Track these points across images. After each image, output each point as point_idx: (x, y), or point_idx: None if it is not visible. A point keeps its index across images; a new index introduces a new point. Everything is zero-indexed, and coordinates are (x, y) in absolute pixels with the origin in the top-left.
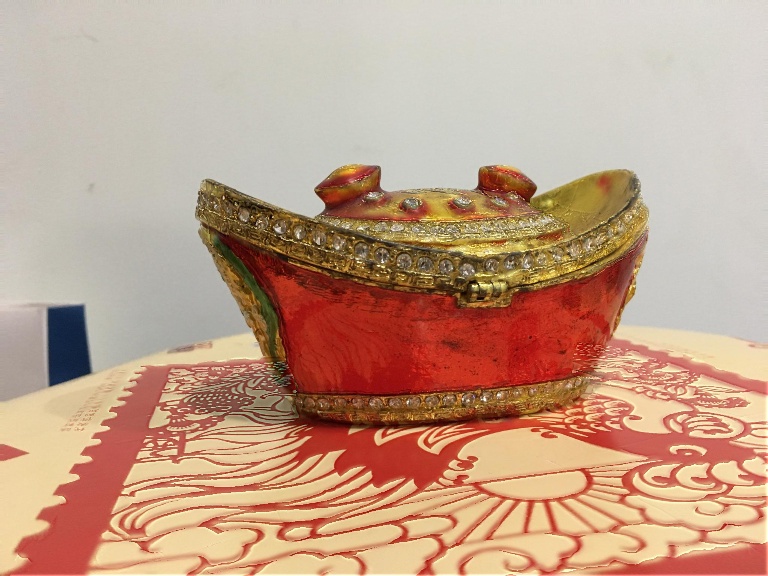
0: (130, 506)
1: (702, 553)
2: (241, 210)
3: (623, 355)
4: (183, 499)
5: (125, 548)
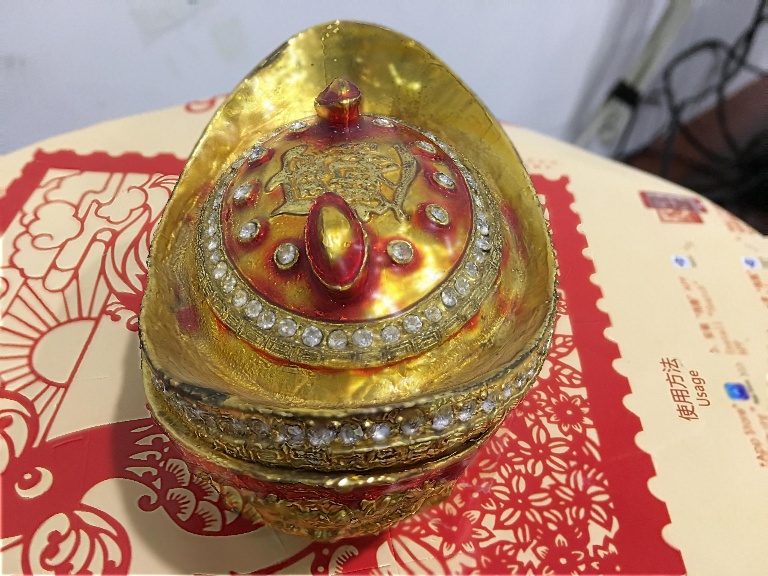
0: None
1: None
2: None
3: None
4: None
5: (138, 181)
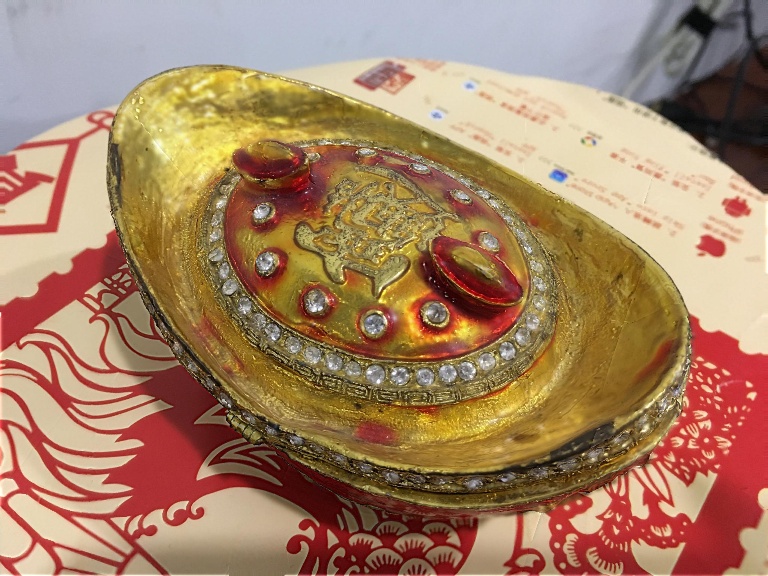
0: (4, 361)
1: None
2: None
3: (680, 475)
4: (27, 380)
5: None
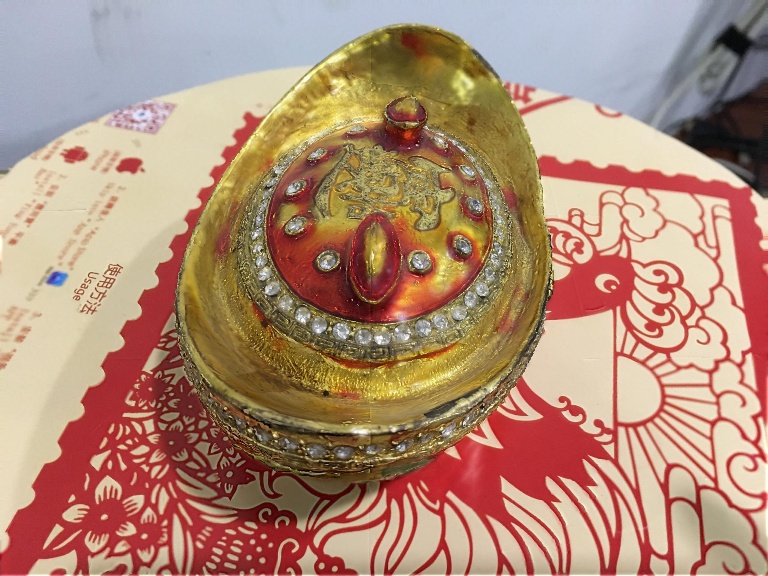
0: None
1: (760, 379)
2: (448, 428)
3: None
4: None
5: None
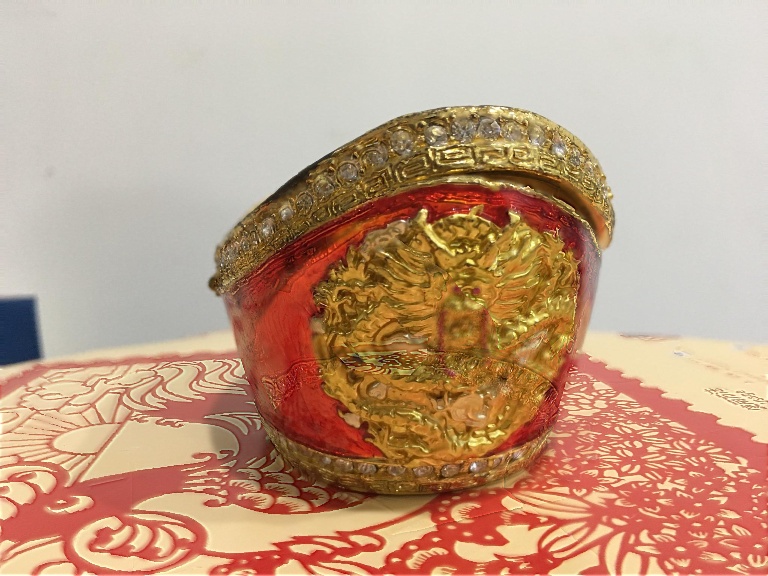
0: None
1: None
2: None
3: None
4: None
5: None
